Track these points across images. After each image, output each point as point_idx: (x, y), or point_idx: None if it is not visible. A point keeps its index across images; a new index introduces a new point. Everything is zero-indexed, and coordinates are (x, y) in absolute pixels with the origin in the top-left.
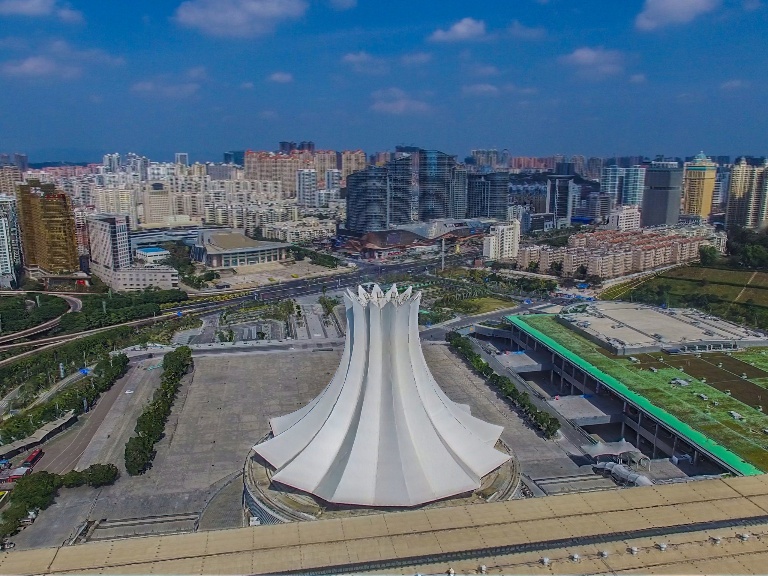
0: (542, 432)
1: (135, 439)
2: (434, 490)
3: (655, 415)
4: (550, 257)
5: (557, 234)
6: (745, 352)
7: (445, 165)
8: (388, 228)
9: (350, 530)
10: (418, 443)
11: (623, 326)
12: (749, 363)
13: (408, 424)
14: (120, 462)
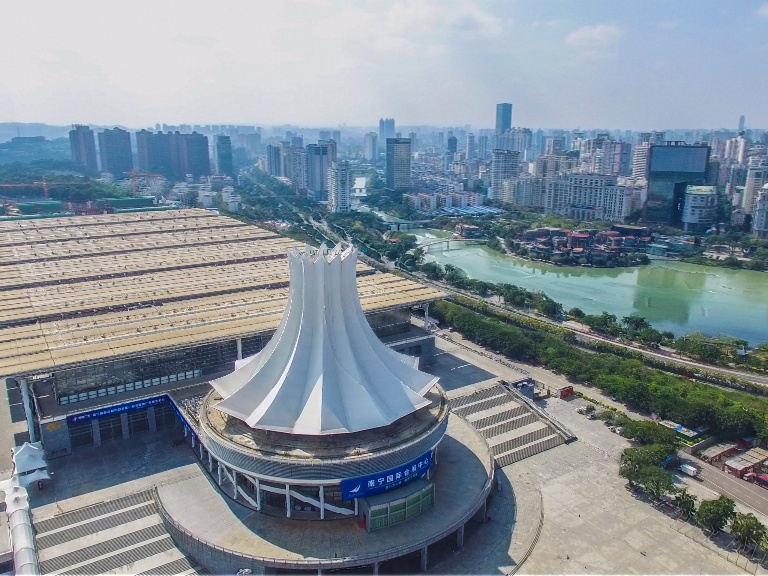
0: None
1: None
2: None
3: None
4: None
5: None
6: None
7: None
8: None
9: None
10: None
11: None
12: None
13: None
14: None
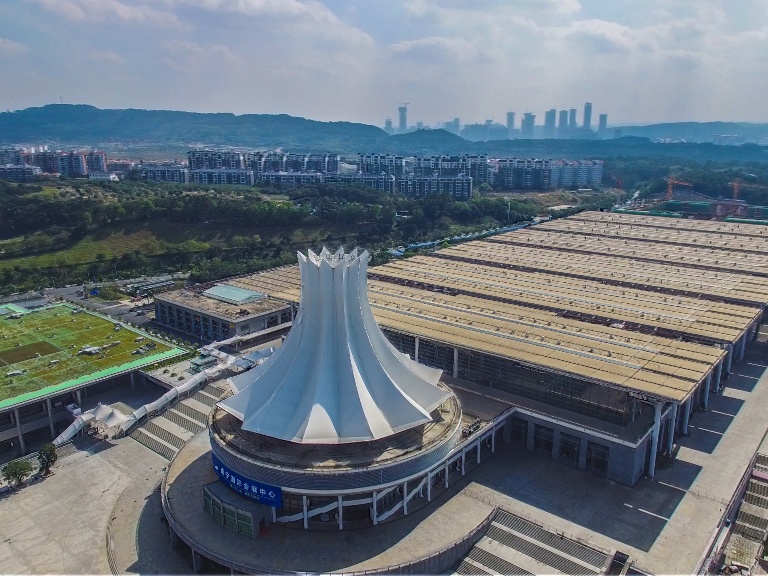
0: (28, 482)
1: None
2: None
3: (30, 399)
4: None
5: None
6: None
7: None
8: None
9: None
10: None
11: None
12: None
13: None
14: None
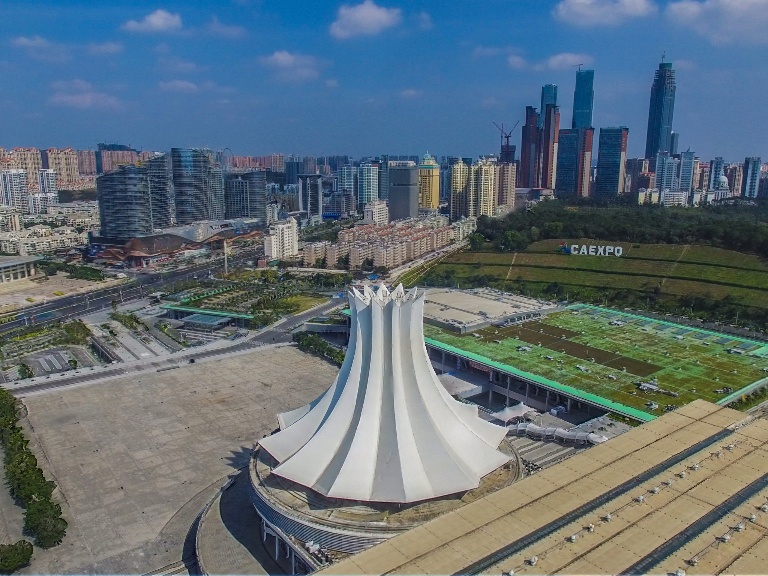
0: None
1: (38, 504)
2: (474, 470)
3: (529, 378)
4: (337, 252)
5: (316, 231)
6: (548, 318)
7: (201, 165)
8: (153, 233)
9: (473, 519)
10: (444, 431)
11: (449, 308)
12: (558, 326)
13: (431, 415)
14: (16, 538)
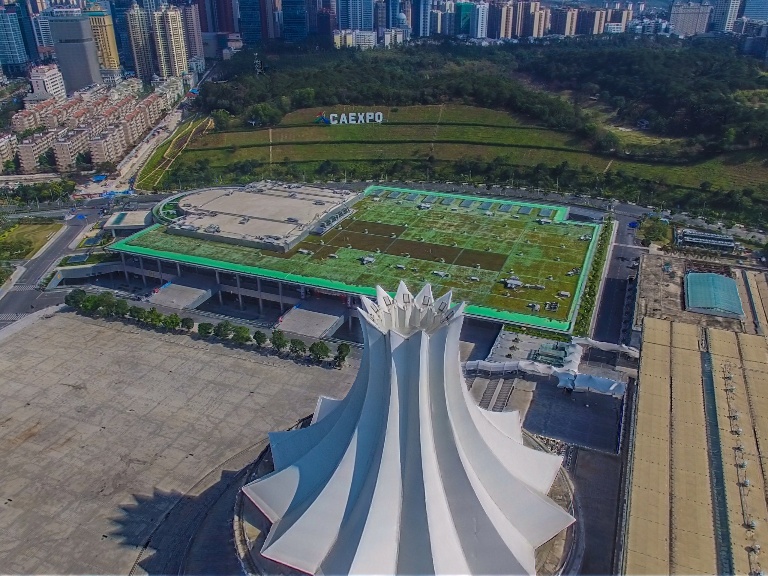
0: (325, 363)
1: None
2: (539, 489)
3: None
4: (34, 151)
5: None
6: (359, 212)
7: None
8: None
9: None
10: None
11: (249, 219)
12: (377, 222)
13: None
14: None
